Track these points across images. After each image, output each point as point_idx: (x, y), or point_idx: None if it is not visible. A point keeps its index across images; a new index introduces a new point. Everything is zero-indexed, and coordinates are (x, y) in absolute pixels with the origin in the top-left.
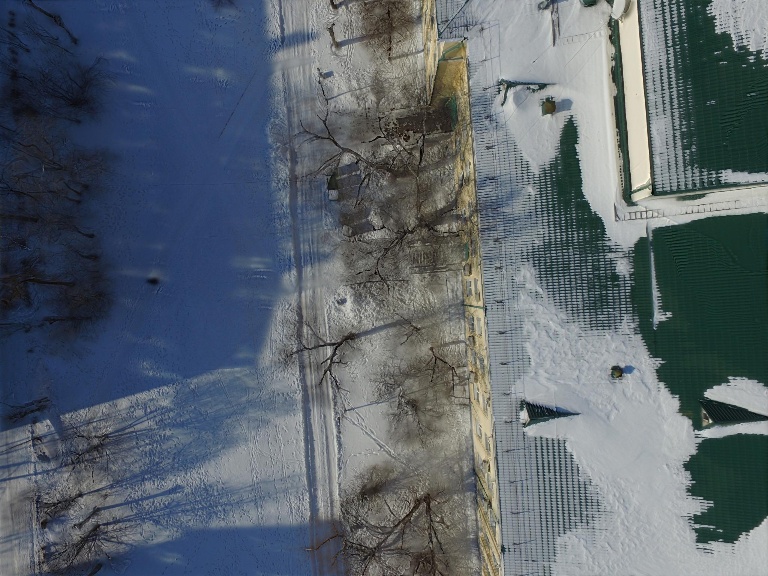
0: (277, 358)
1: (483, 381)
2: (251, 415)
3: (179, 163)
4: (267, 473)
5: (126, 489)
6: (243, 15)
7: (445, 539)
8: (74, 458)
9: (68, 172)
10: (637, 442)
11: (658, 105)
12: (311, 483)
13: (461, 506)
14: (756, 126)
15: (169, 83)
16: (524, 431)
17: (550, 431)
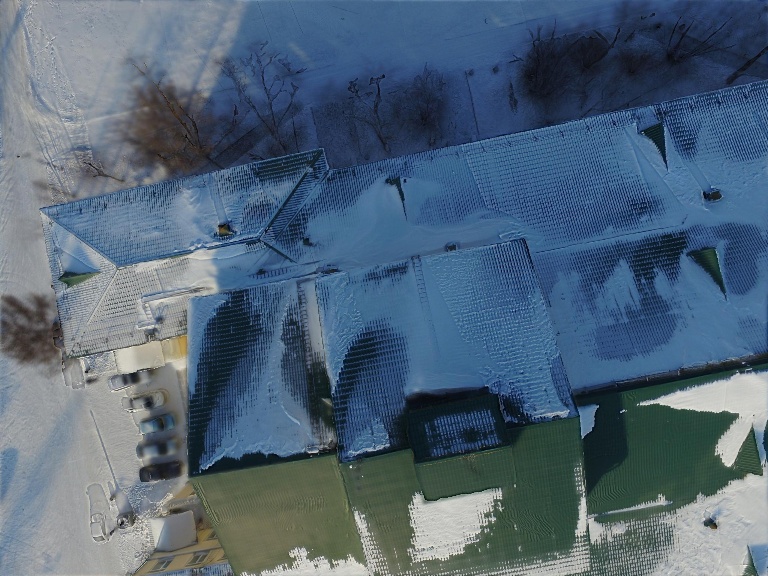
0: None
1: None
2: None
3: None
4: None
5: None
6: None
7: None
8: None
9: None
10: None
11: None
12: None
13: None
14: None
15: None
16: None
17: (763, 564)
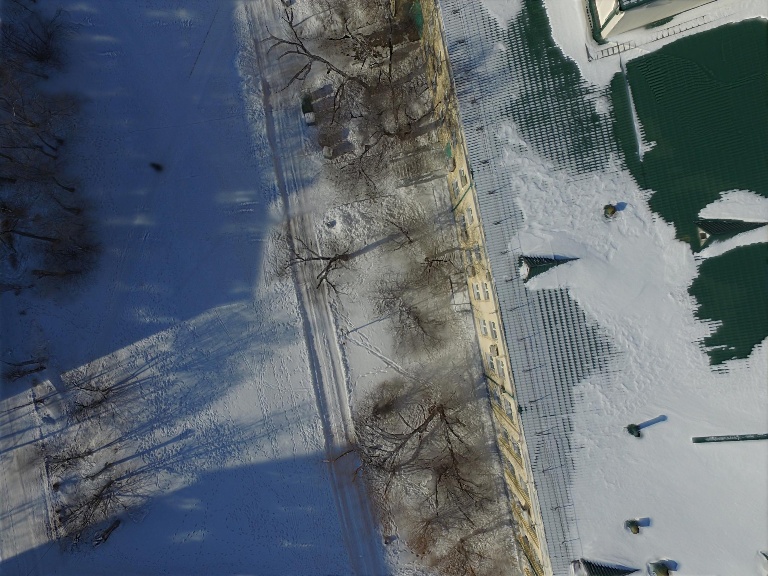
0: (273, 289)
1: (480, 266)
2: (254, 349)
3: (152, 107)
4: (277, 405)
5: (136, 440)
6: None
7: (464, 449)
8: (79, 417)
9: (41, 129)
10: (639, 276)
11: None
12: (322, 410)
13: (476, 413)
14: None
15: (133, 30)
16: (525, 287)
17: (551, 281)
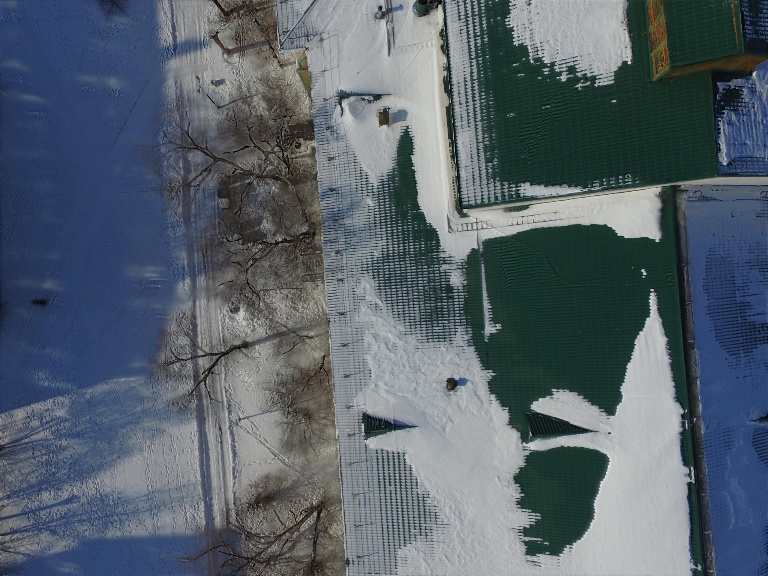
0: (172, 367)
1: None
2: (146, 425)
3: (73, 172)
4: (162, 482)
5: (23, 499)
6: (135, 23)
7: (340, 547)
8: None
9: None
10: (470, 454)
11: (463, 118)
12: (206, 492)
13: None
14: (560, 138)
15: (62, 92)
16: (366, 444)
17: (390, 444)
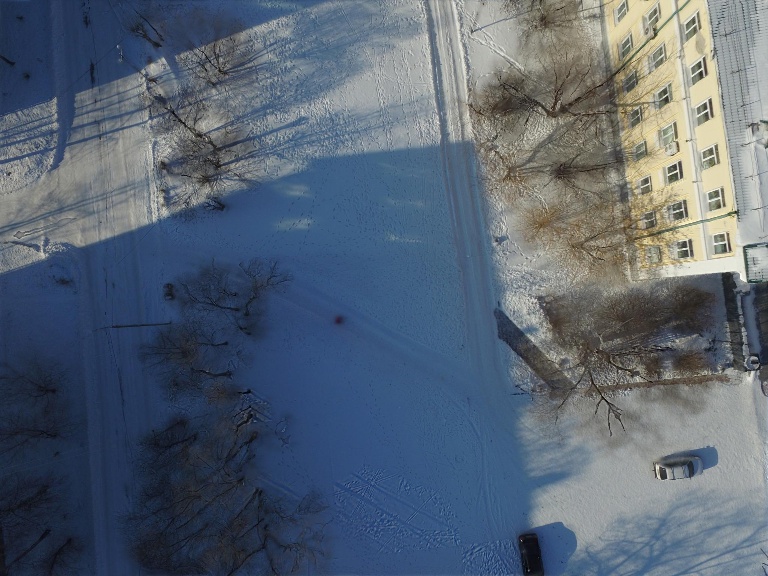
0: None
1: None
2: (375, 41)
3: None
4: (394, 98)
5: (248, 125)
6: None
7: (581, 155)
8: (191, 99)
9: None
10: None
11: None
12: (440, 107)
13: None
14: None
15: None
16: None
17: None
